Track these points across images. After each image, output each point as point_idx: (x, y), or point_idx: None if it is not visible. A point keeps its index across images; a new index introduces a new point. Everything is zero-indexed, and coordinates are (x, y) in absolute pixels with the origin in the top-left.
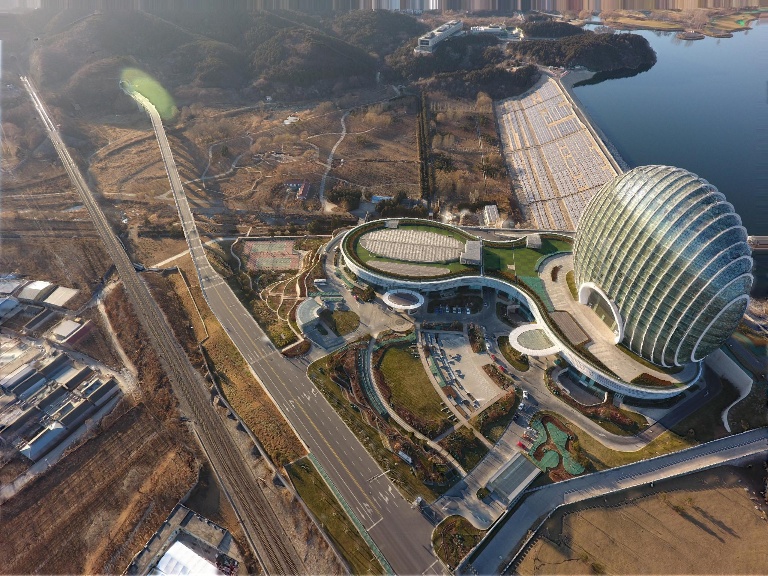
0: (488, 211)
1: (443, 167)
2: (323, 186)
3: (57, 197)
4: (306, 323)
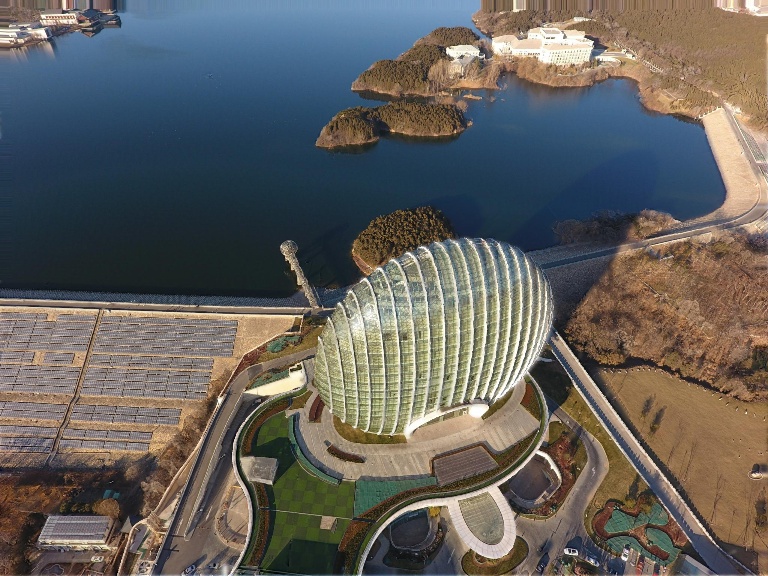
0: (63, 537)
1: None
2: None
3: None
4: None
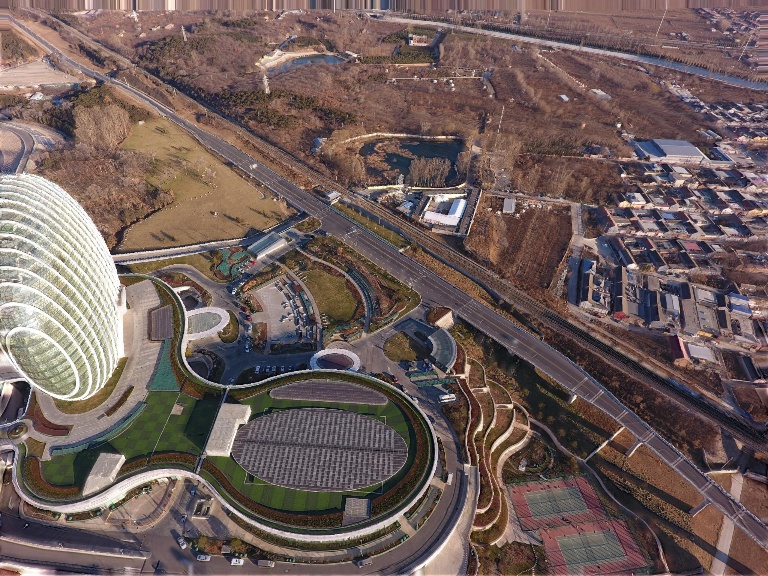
0: None
1: None
2: None
3: None
4: (439, 330)
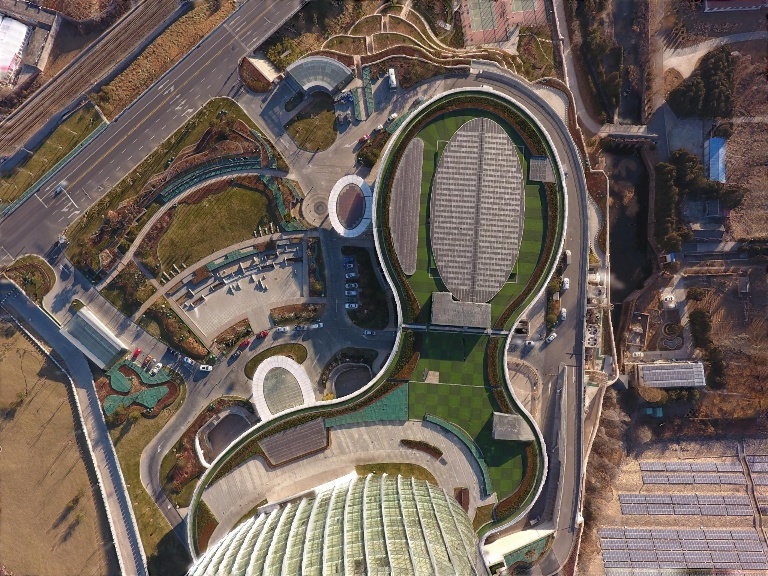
0: (680, 367)
1: None
2: (764, 36)
3: None
4: (292, 75)
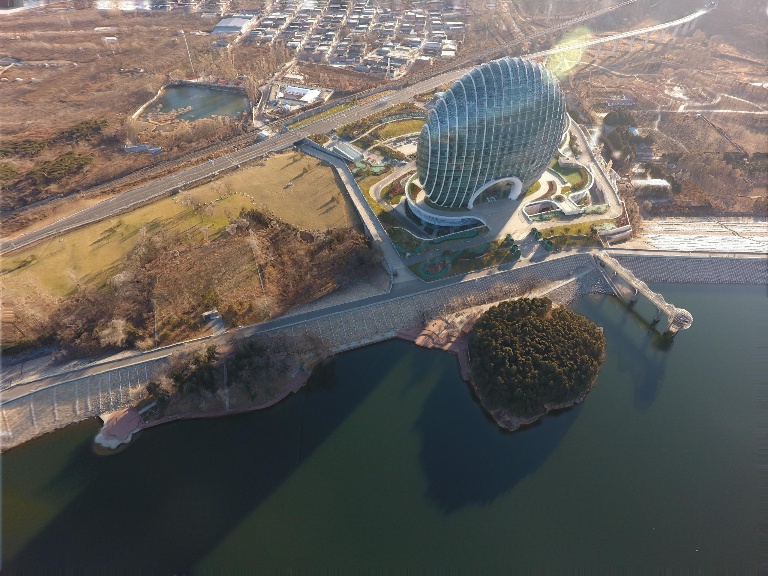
0: (653, 180)
1: (740, 163)
2: None
3: (541, 36)
4: (438, 95)
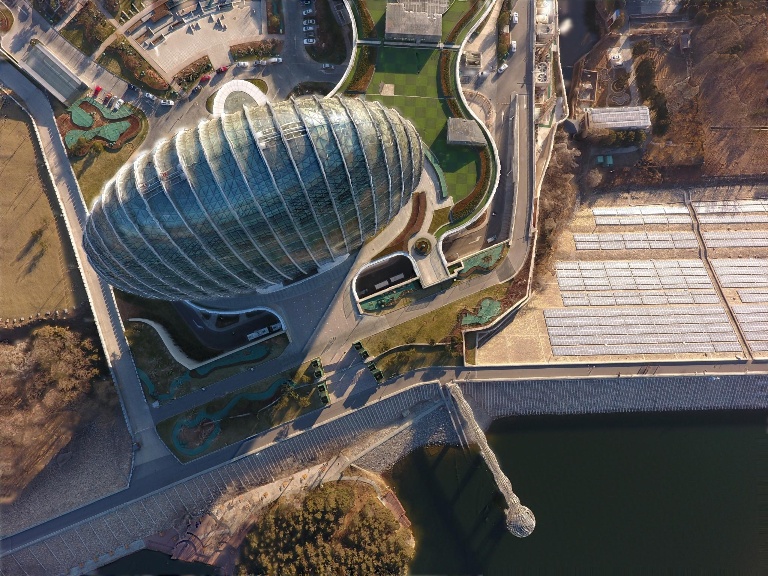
0: (627, 109)
1: None
2: None
3: None
4: None
